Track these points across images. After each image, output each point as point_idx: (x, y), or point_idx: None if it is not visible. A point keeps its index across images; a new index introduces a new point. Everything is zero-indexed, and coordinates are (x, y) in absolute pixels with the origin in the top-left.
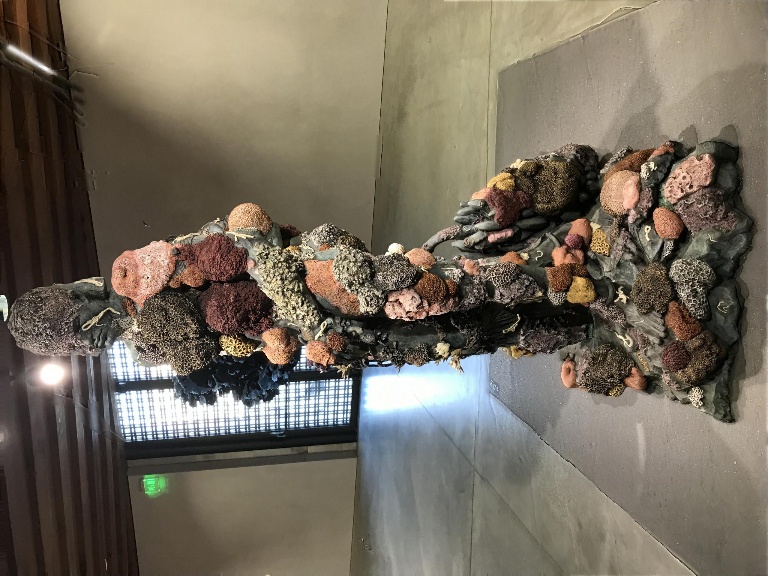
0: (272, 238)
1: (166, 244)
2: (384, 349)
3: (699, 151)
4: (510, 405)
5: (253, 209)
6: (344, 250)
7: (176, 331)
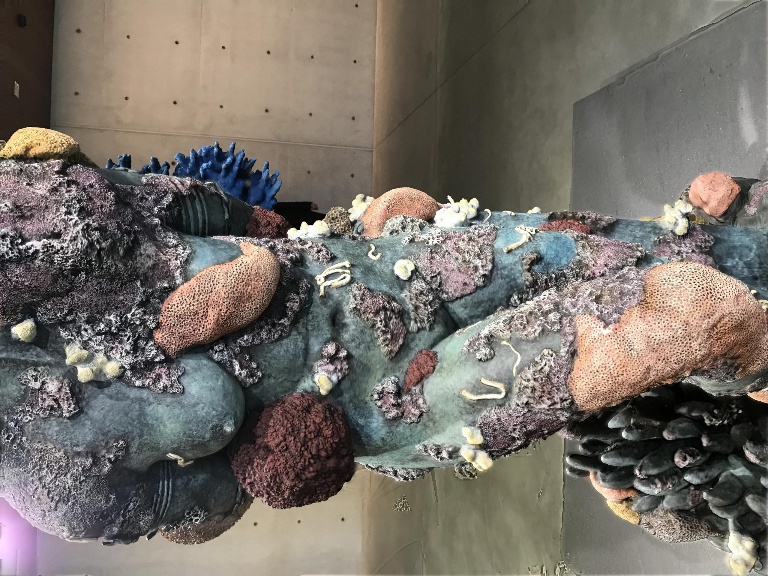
0: None
1: None
2: None
3: None
4: None
5: None
6: None
7: None
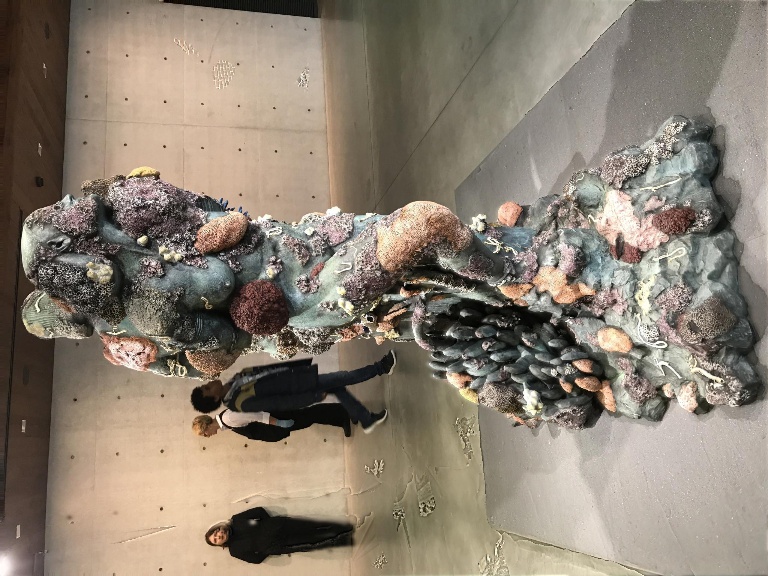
0: None
1: None
2: None
3: None
4: None
5: None
6: None
7: None
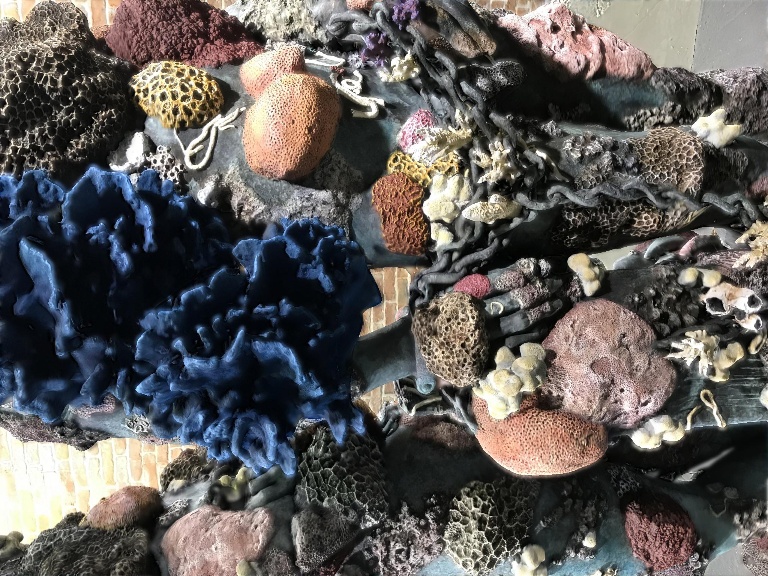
0: None
1: None
2: (569, 139)
3: None
4: None
5: None
6: None
7: (24, 41)
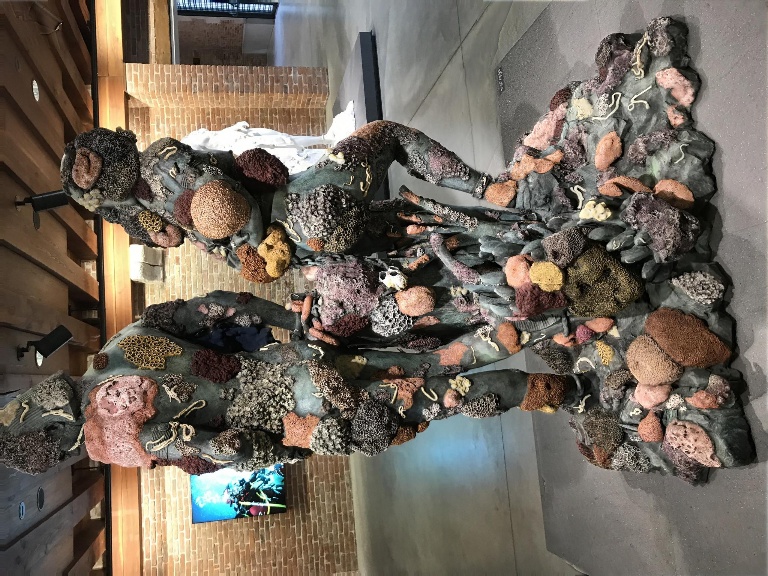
0: (249, 234)
1: (140, 455)
2: None
3: (720, 454)
4: (503, 126)
5: (225, 220)
6: (324, 433)
7: None
